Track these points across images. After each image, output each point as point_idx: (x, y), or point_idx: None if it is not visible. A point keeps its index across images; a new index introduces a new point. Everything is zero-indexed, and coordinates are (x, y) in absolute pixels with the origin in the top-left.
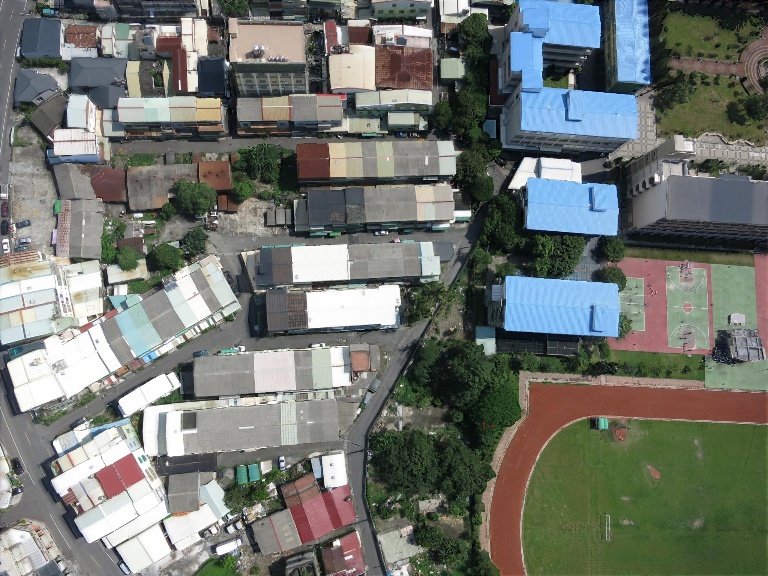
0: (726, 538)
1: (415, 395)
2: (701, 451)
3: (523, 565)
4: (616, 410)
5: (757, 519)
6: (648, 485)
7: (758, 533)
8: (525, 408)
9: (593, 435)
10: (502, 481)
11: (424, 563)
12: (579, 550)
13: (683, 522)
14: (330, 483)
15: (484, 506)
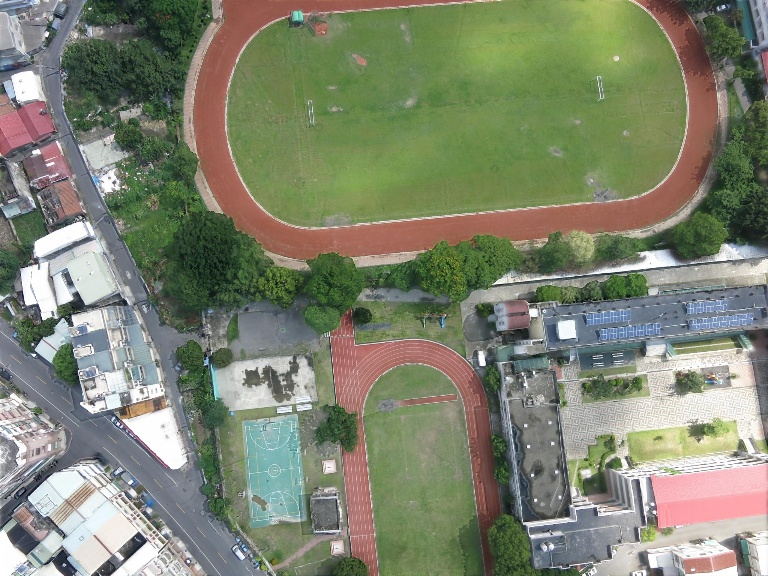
0: (442, 113)
1: (104, 16)
2: (409, 35)
3: (231, 159)
4: (315, 7)
5: (474, 92)
6: (355, 73)
7: (476, 105)
8: (220, 16)
9: (293, 33)
10: (202, 85)
11: (130, 166)
12: (288, 139)
13: (395, 103)
14: (21, 98)
15: (180, 104)
